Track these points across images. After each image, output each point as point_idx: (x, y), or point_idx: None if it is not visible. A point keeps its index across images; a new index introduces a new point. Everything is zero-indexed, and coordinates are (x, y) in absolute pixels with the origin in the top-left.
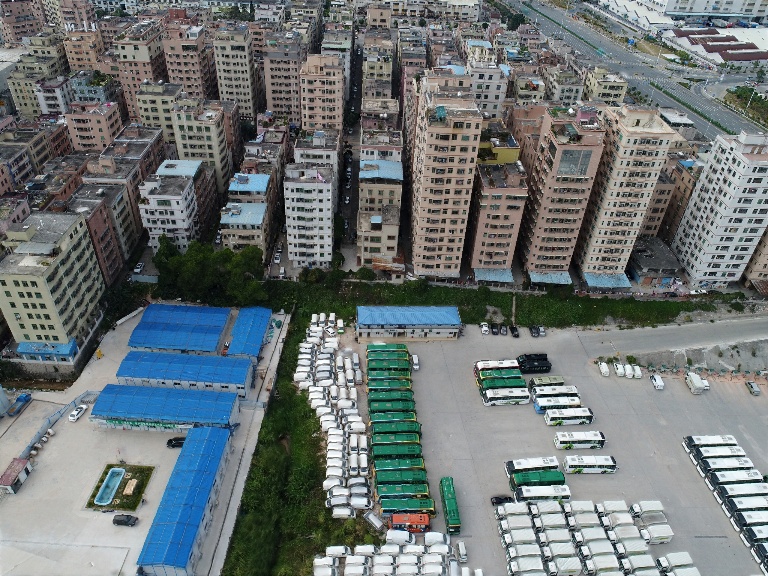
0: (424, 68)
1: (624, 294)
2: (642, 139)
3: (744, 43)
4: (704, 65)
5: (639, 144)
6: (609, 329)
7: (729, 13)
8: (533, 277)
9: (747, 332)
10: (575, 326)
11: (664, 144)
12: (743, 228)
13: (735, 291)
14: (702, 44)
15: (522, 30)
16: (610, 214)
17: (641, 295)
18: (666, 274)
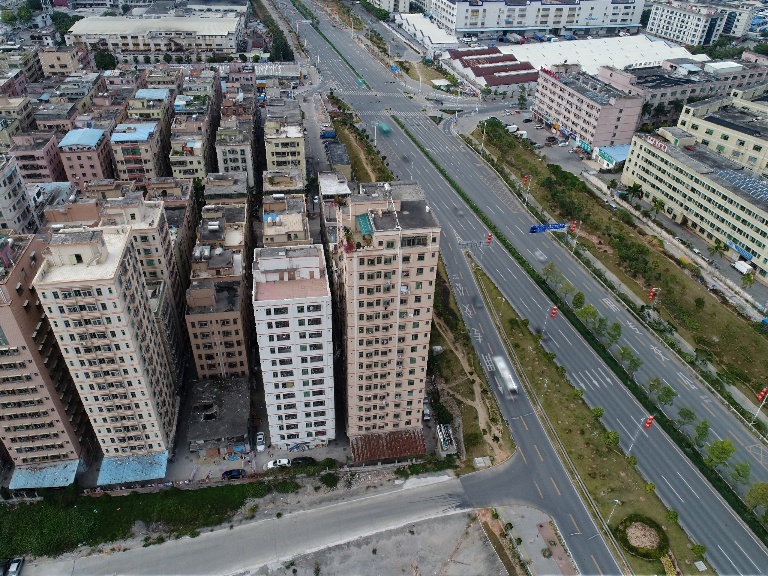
0: (49, 135)
1: (160, 485)
2: (63, 291)
3: (518, 63)
4: (469, 92)
5: (63, 298)
6: (128, 547)
7: (524, 26)
8: (15, 480)
9: (317, 533)
10: (80, 548)
11: (106, 293)
12: (300, 381)
13: (337, 450)
14: (471, 67)
15: (233, 68)
16: (89, 387)
17: (186, 483)
18: (231, 442)
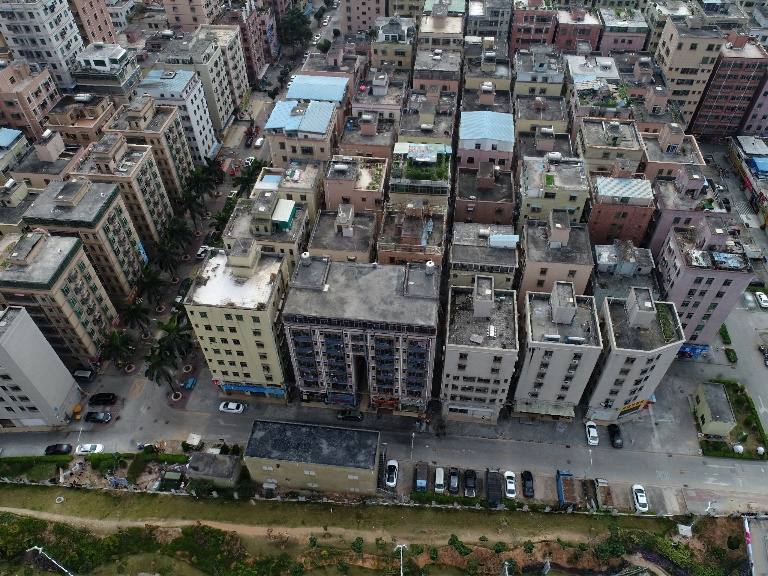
0: None
1: None
2: None
3: None
4: None
5: None
6: None
7: None
8: None
9: None
10: None
11: None
12: None
13: None
14: None
15: None
16: None
17: None
18: None
